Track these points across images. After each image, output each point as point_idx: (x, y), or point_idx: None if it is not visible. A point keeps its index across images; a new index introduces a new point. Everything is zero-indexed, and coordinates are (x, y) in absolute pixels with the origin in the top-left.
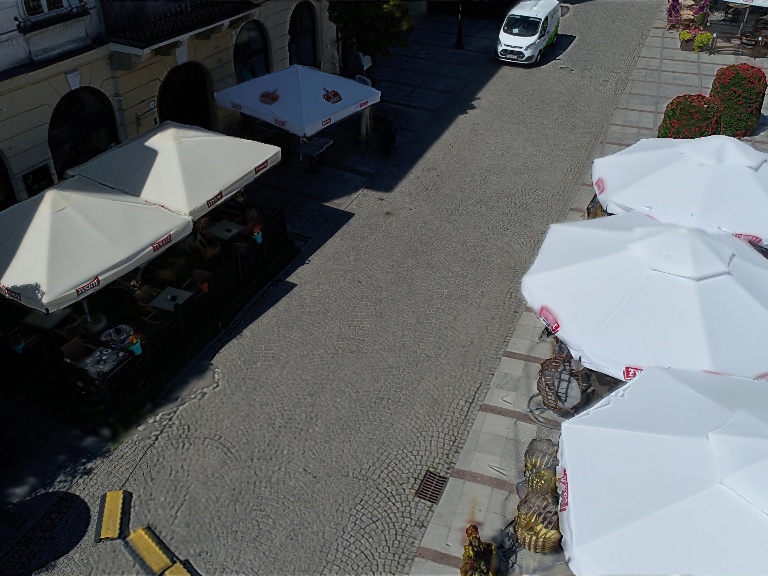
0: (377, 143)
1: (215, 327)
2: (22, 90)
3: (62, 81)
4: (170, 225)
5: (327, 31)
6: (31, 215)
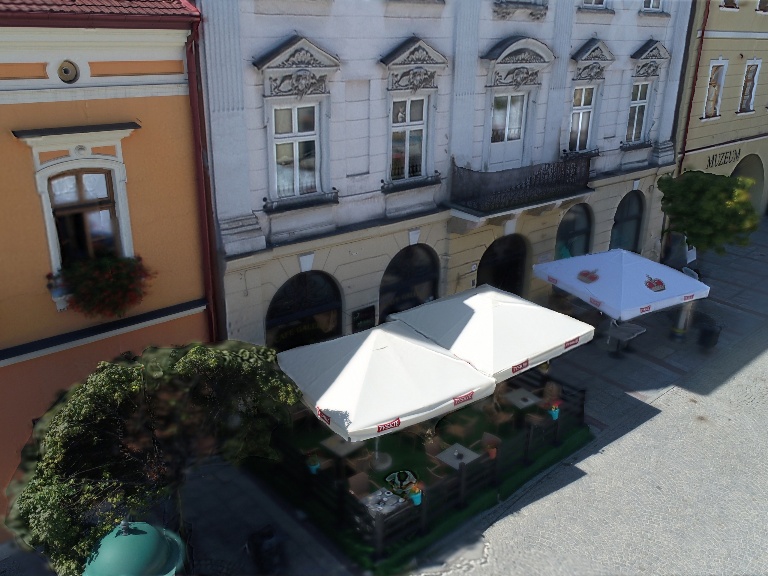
0: (695, 340)
1: (493, 497)
2: (372, 240)
3: (404, 236)
4: (474, 383)
5: (653, 221)
6: (356, 348)
